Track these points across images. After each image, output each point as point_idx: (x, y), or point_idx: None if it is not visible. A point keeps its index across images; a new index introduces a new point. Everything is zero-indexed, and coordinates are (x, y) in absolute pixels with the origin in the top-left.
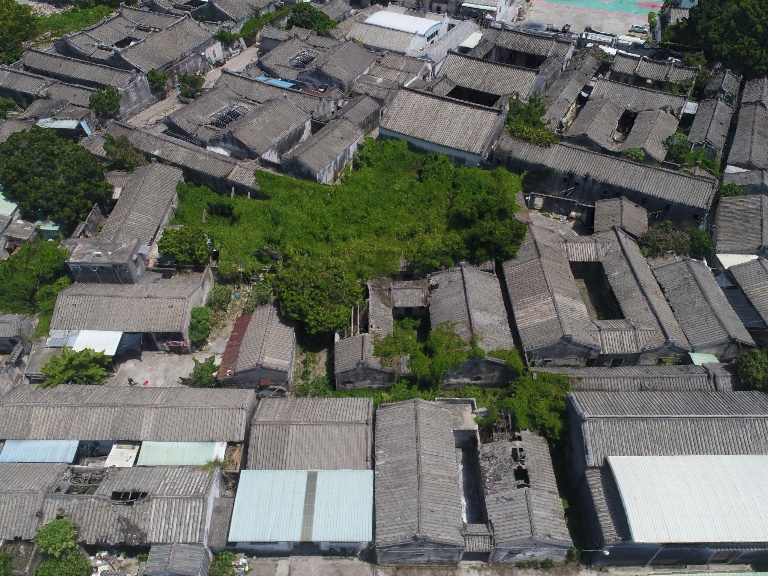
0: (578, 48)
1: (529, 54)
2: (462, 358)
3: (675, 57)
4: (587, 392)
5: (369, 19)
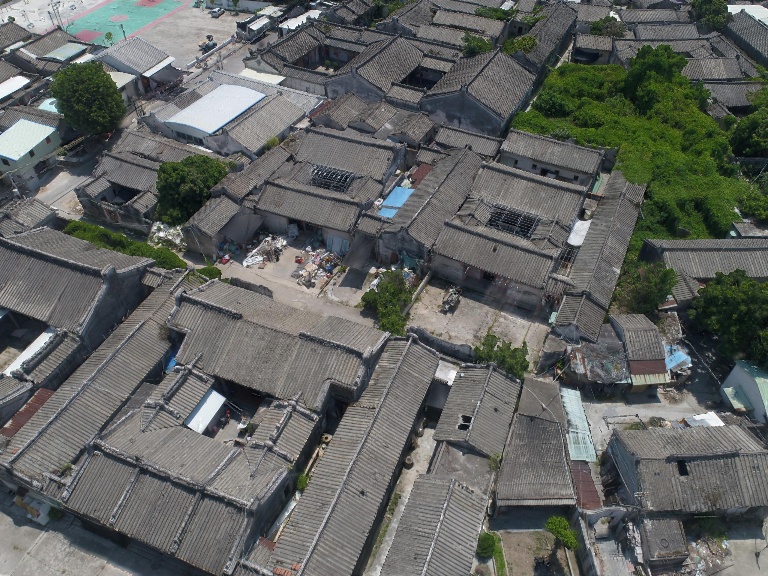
0: (254, 42)
1: (310, 51)
2: None
3: (313, 1)
4: None
5: (206, 128)
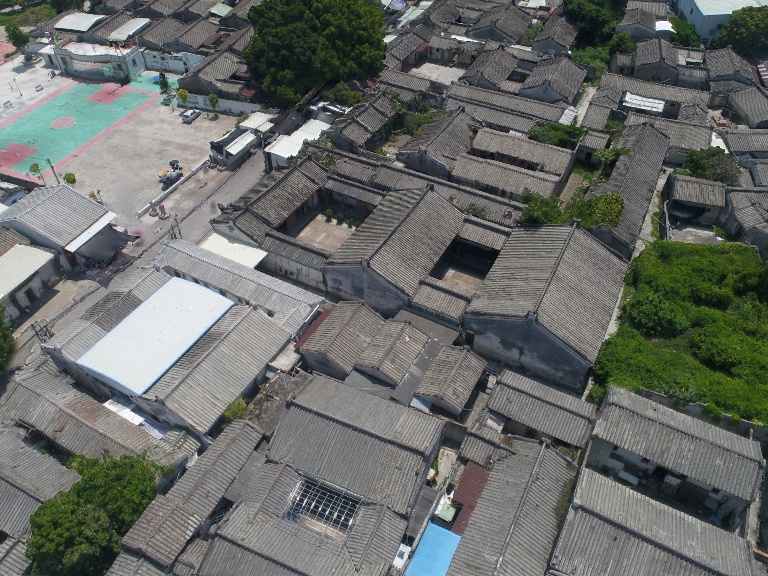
0: (233, 169)
1: None
2: None
3: (314, 104)
4: None
5: (133, 384)
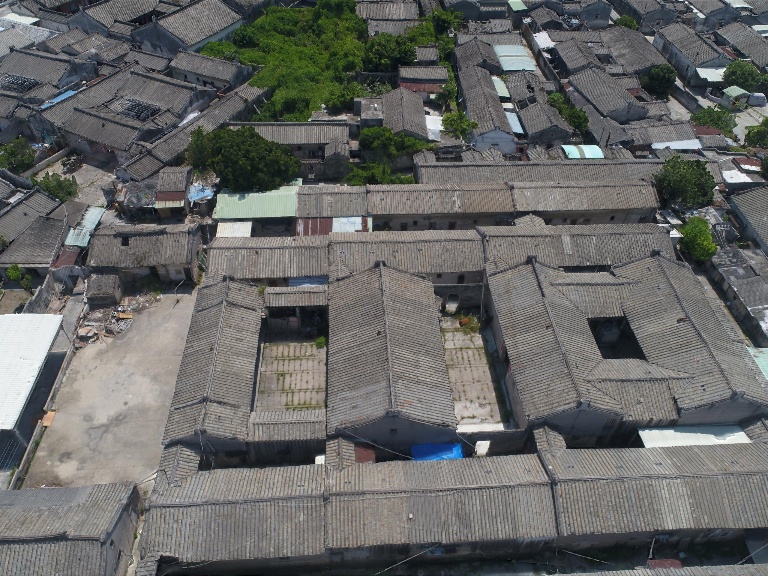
0: None
1: (74, 0)
2: (431, 23)
3: None
4: (445, 3)
5: None
